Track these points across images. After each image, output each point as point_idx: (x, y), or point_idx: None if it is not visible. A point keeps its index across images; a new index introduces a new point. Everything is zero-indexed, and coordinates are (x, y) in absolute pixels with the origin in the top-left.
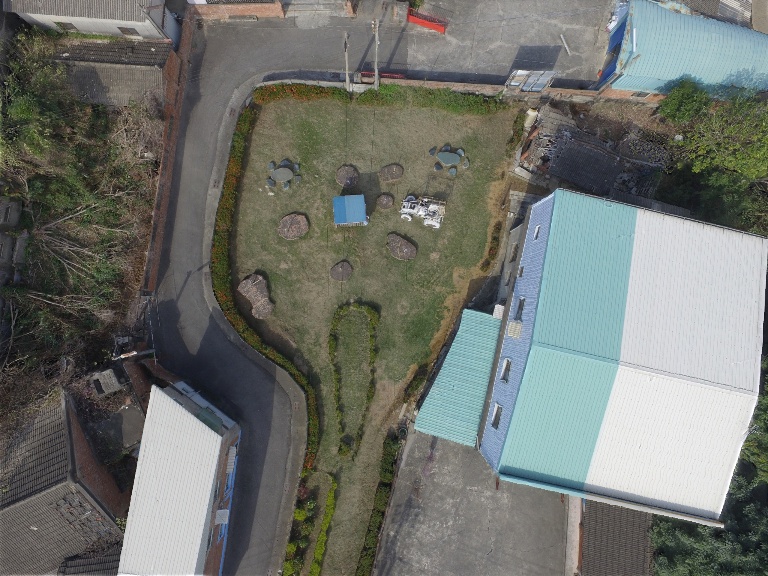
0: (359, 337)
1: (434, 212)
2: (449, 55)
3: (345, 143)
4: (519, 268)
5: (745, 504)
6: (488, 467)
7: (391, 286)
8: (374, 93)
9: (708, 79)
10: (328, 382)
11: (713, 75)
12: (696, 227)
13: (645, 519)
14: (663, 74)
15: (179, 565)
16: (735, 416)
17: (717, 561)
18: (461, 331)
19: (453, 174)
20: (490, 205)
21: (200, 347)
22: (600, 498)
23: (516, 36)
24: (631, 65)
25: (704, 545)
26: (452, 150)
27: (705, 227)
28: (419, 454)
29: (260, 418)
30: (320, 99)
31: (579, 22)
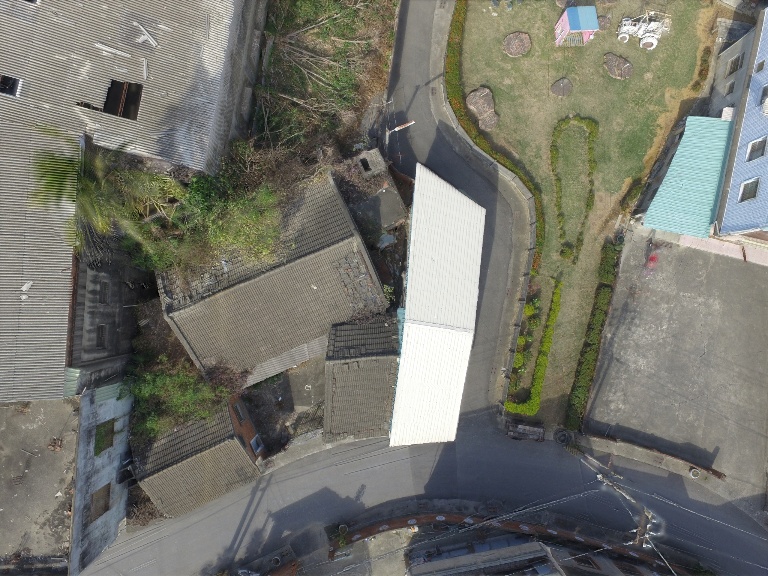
0: (577, 151)
1: (653, 30)
2: None
3: None
4: (754, 66)
5: None
6: (700, 275)
7: (607, 103)
8: None
9: None
10: (549, 192)
11: None
12: None
13: None
14: None
15: (460, 315)
16: None
17: None
18: (686, 136)
19: None
20: (699, 31)
21: (428, 156)
22: None
23: None
24: None
25: None
26: None
27: None
28: (634, 262)
29: None
30: None
31: None
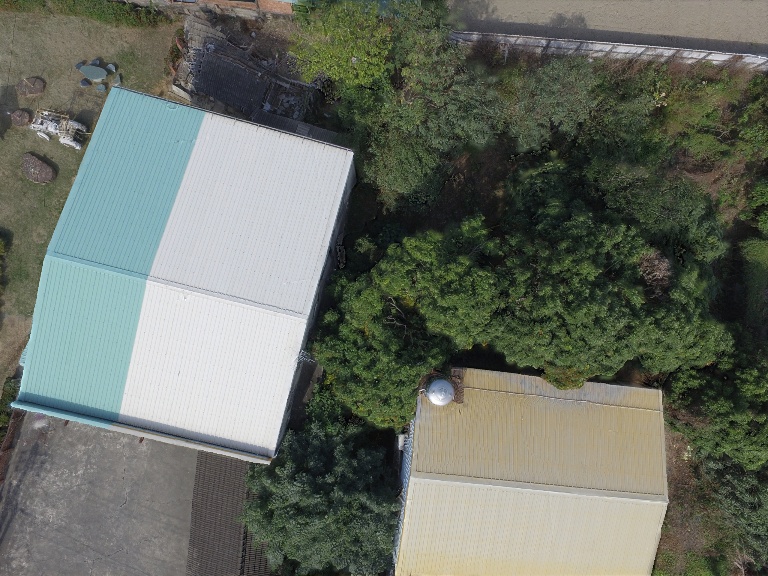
0: None
1: (68, 130)
2: None
3: None
4: None
5: (337, 445)
6: None
7: (25, 211)
8: None
9: None
10: None
11: None
12: (271, 135)
13: (245, 463)
14: None
15: None
16: (284, 341)
17: (296, 506)
18: None
19: (101, 91)
20: None
21: None
22: (127, 429)
23: None
24: None
25: (278, 488)
26: (103, 65)
27: (282, 136)
28: None
29: None
30: None
31: None
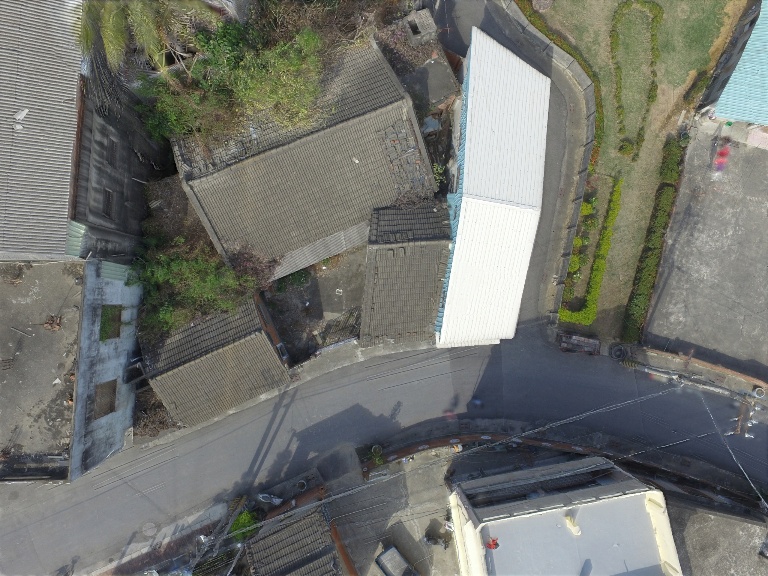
0: (639, 38)
1: None
2: None
3: None
4: None
5: None
6: None
7: None
8: None
9: None
10: (607, 82)
11: None
12: None
13: None
14: None
15: (525, 191)
16: None
17: None
18: (761, 19)
19: None
20: None
21: None
22: None
23: None
24: None
25: None
26: None
27: None
28: (698, 162)
29: None
30: None
31: None
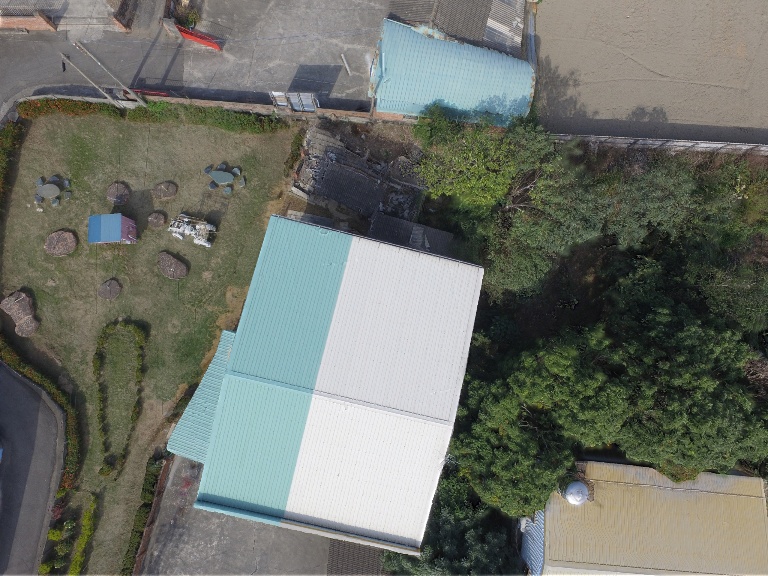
0: (127, 356)
1: None
2: (226, 73)
3: (118, 160)
4: None
5: (467, 529)
6: None
7: (162, 305)
8: (143, 110)
9: (461, 105)
10: (94, 401)
11: (465, 101)
12: (411, 256)
13: None
14: (416, 99)
15: None
16: (432, 445)
17: None
18: (218, 352)
19: (228, 193)
20: None
21: None
22: (295, 526)
23: (296, 55)
24: (382, 89)
25: (418, 571)
26: (229, 168)
27: (421, 256)
28: (186, 474)
29: (23, 437)
30: (91, 115)
31: (361, 42)
